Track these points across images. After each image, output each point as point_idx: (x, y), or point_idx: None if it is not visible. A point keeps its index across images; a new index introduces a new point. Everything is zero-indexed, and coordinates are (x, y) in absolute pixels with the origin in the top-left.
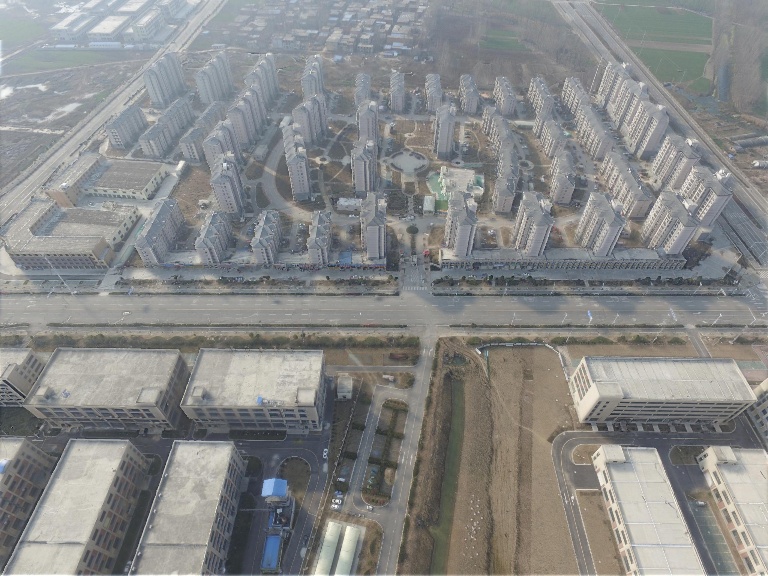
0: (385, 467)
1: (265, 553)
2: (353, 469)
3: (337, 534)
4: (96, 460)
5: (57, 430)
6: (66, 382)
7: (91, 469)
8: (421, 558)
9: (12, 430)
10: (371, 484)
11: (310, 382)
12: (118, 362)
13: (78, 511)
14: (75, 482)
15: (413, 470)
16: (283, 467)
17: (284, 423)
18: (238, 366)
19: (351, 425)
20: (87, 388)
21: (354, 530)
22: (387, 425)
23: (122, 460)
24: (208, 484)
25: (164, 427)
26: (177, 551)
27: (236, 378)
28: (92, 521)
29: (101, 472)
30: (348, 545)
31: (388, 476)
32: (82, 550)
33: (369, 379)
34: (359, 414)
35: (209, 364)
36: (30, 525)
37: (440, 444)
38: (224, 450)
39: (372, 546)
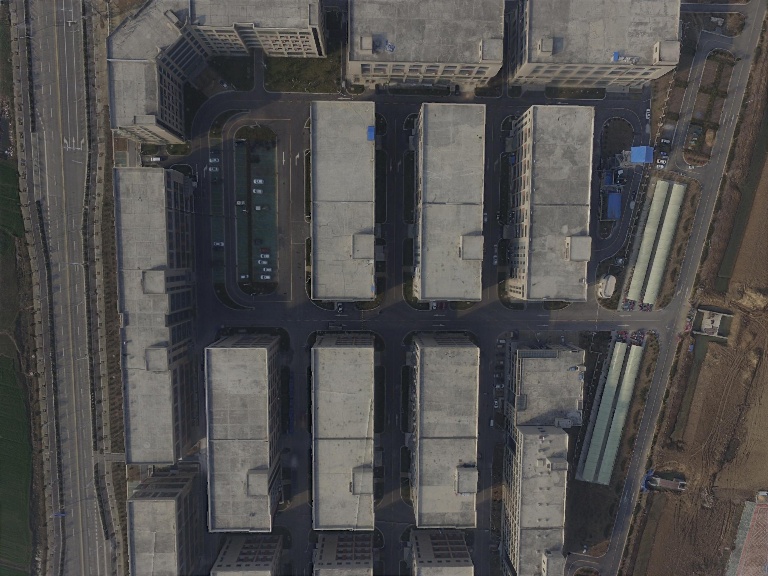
0: (707, 128)
1: (608, 207)
2: (675, 130)
3: (666, 191)
4: (458, 126)
5: (361, 87)
6: (383, 30)
7: (457, 136)
8: (731, 209)
9: (311, 86)
10: (693, 145)
11: (667, 32)
12: (433, 1)
13: (461, 176)
14: (446, 149)
15: (734, 131)
16: (607, 128)
17: (613, 81)
18: (580, 8)
19: (674, 82)
20: (411, 39)
21: (682, 188)
22: (711, 82)
23: (484, 126)
24: (576, 151)
25: (476, 84)
26: (563, 210)
27: (581, 26)
28: (478, 185)
29: (468, 139)
30: (677, 200)
31: (711, 138)
32: (479, 209)
33: (694, 22)
34: (682, 69)
35: (544, 5)
36: (423, 189)
37: (762, 104)
38: (585, 116)
39: (693, 200)
